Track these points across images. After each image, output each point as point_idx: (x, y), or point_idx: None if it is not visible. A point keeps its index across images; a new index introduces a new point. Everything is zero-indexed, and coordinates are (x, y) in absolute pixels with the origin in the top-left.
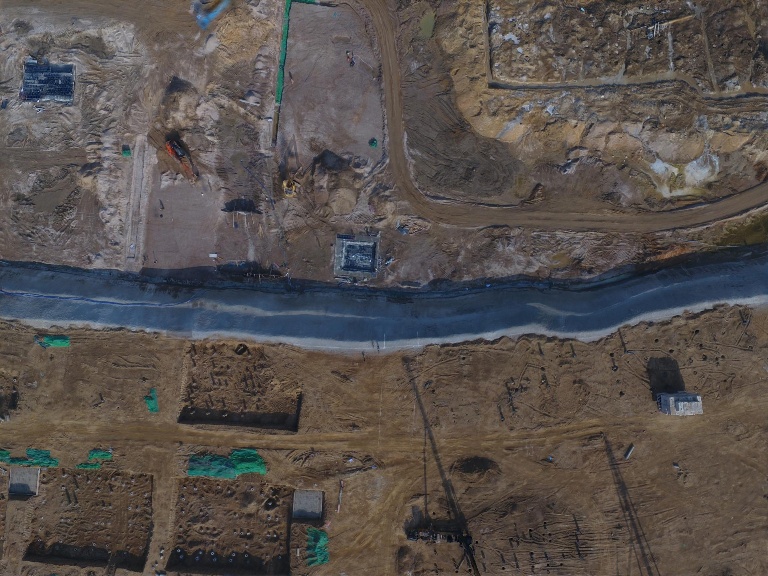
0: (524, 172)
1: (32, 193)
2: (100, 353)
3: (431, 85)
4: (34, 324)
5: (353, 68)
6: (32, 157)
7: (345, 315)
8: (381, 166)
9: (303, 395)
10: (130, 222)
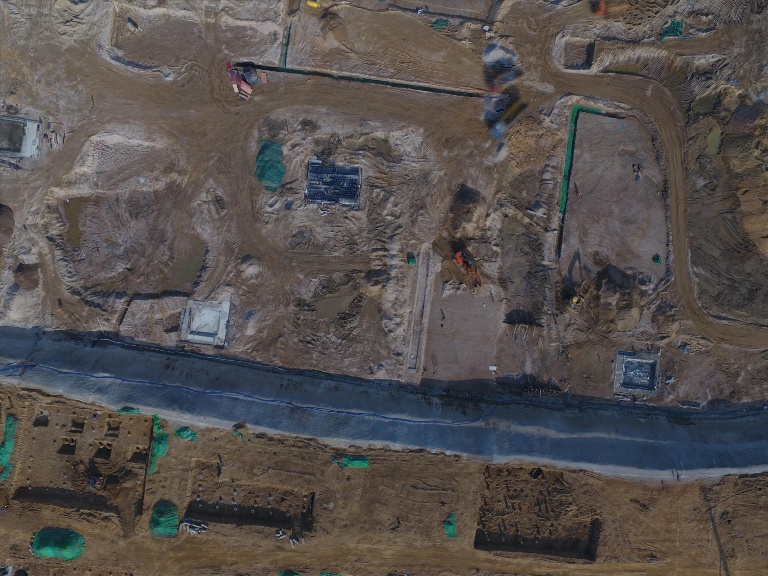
0: None
1: (314, 298)
2: (399, 475)
3: (716, 202)
4: (332, 443)
5: (638, 182)
6: (315, 261)
7: (636, 438)
8: (665, 283)
9: (601, 523)
10: (412, 331)
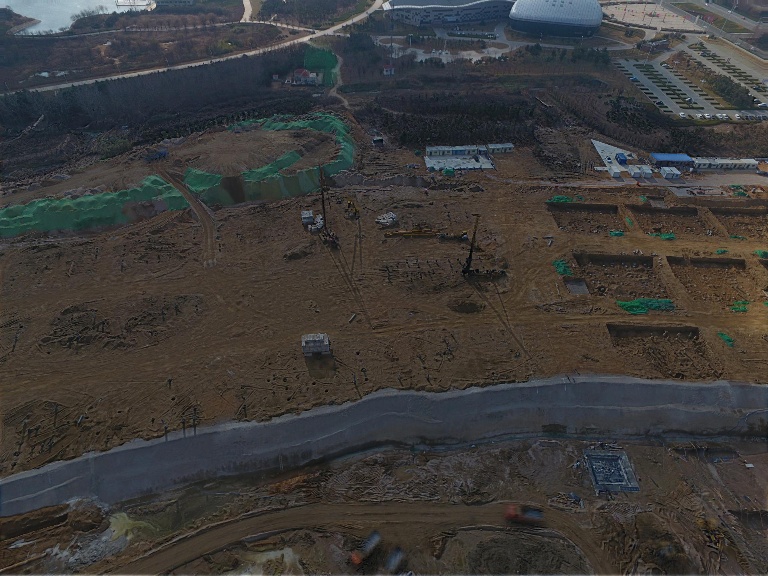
0: (458, 574)
1: None
2: None
3: None
4: None
5: None
6: None
7: (604, 408)
8: (628, 574)
9: None
10: None
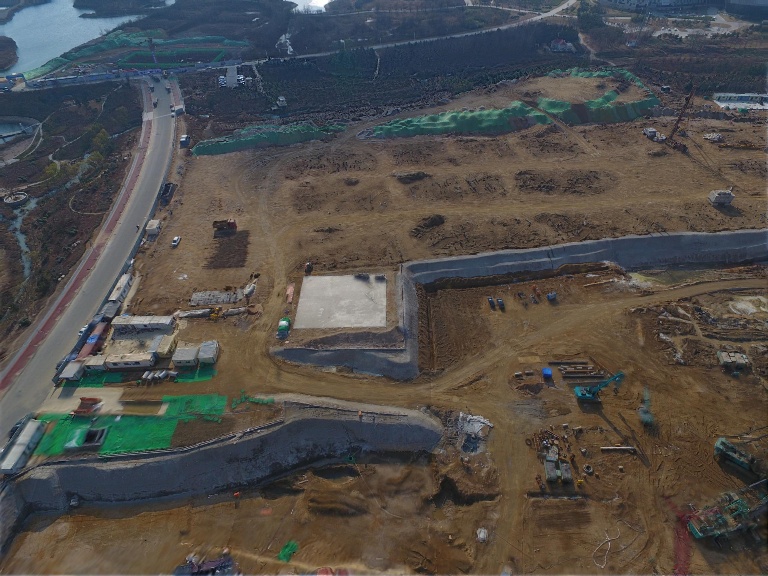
0: None
1: None
2: None
3: None
4: None
5: None
6: None
7: None
8: None
9: None
10: None
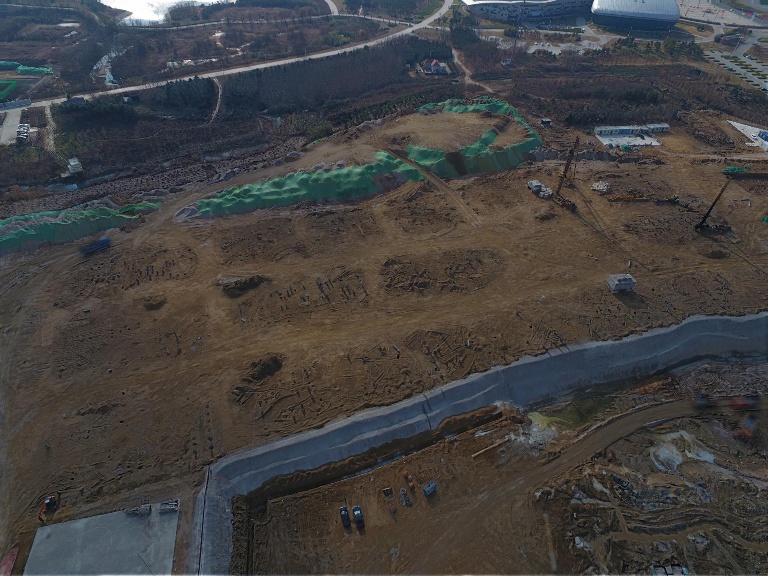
0: None
1: None
2: None
3: None
4: None
5: None
6: None
7: None
8: None
9: None
10: None
